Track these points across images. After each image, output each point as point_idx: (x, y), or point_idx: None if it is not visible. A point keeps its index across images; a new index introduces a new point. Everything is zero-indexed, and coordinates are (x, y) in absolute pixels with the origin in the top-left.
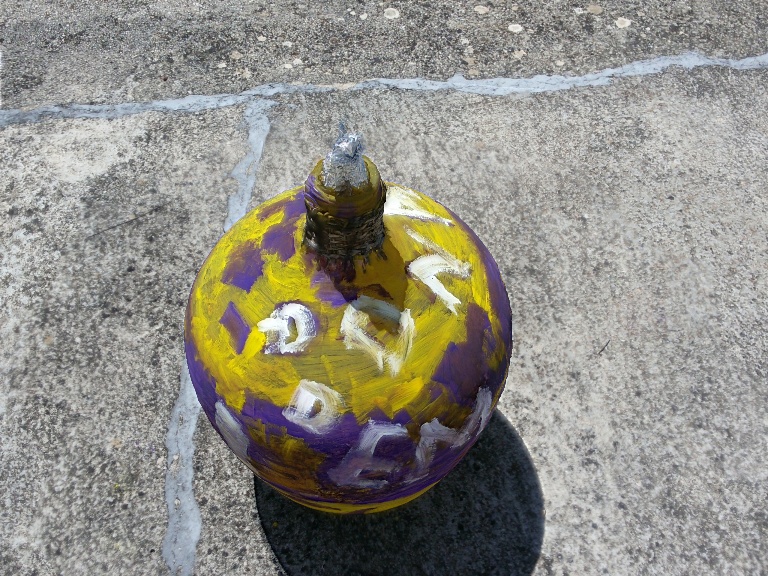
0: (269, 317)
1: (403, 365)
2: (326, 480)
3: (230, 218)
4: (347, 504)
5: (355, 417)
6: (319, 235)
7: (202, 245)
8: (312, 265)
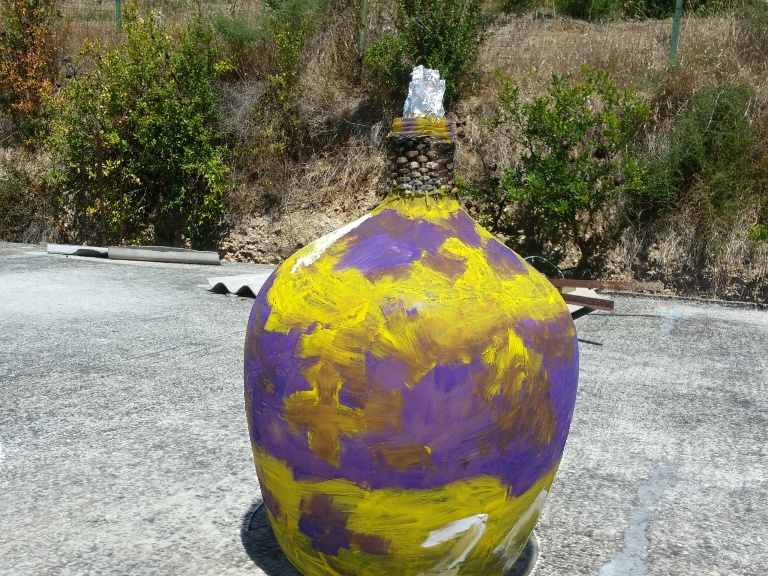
0: None
1: None
2: None
3: None
4: None
5: None
6: None
7: None
8: None
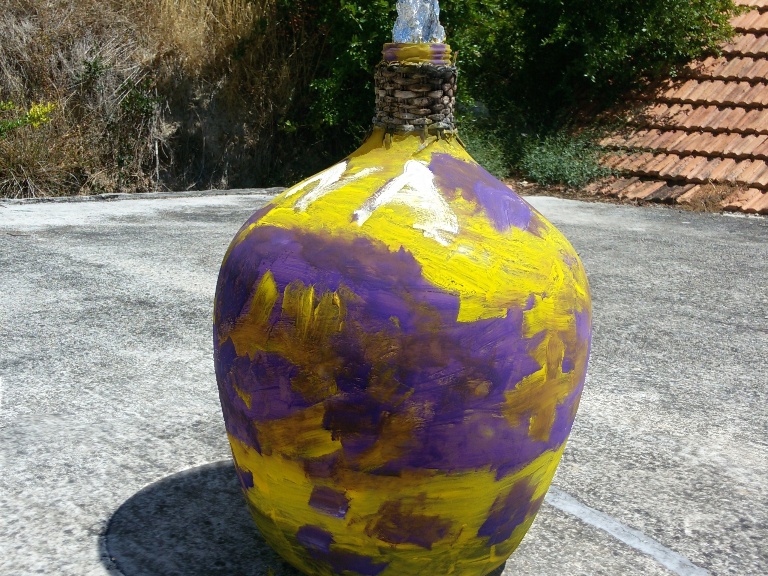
0: None
1: None
2: None
3: None
4: None
5: None
6: None
7: None
8: None
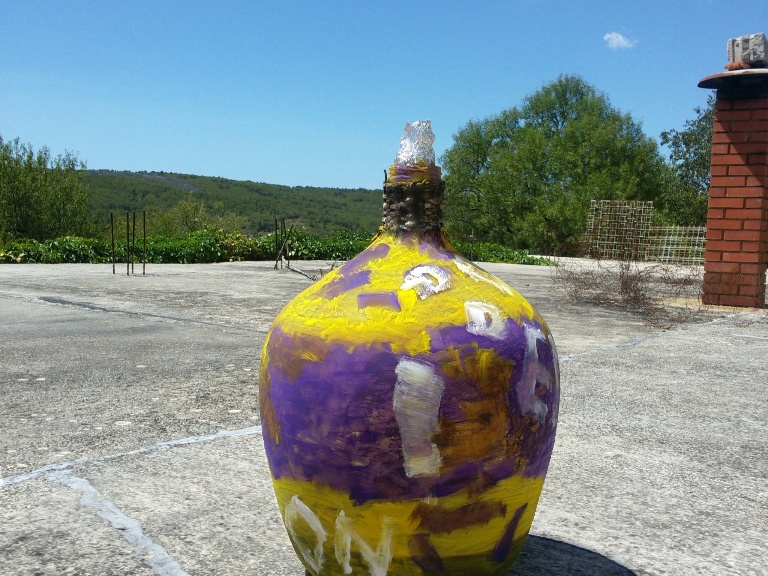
0: (405, 282)
1: None
2: (514, 407)
3: (115, 522)
4: (518, 478)
5: (515, 322)
6: (415, 212)
7: (106, 541)
8: (413, 244)
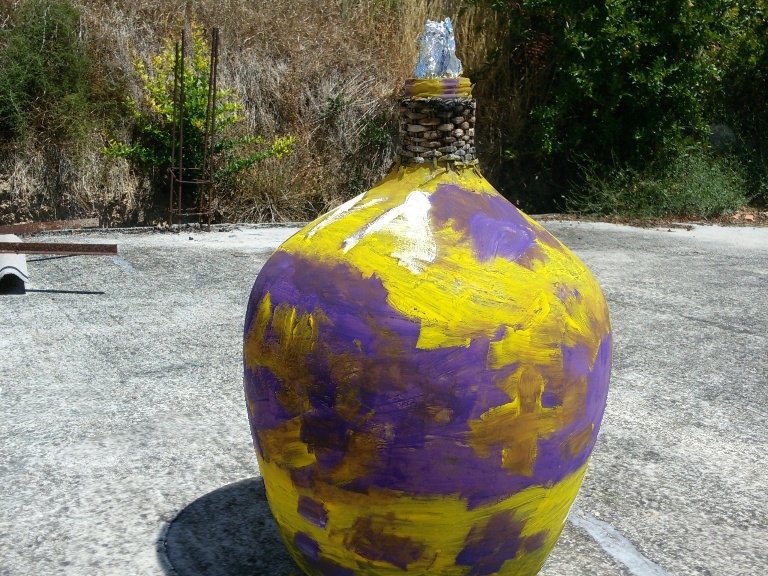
0: None
1: None
2: None
3: None
4: None
5: None
6: None
7: None
8: None
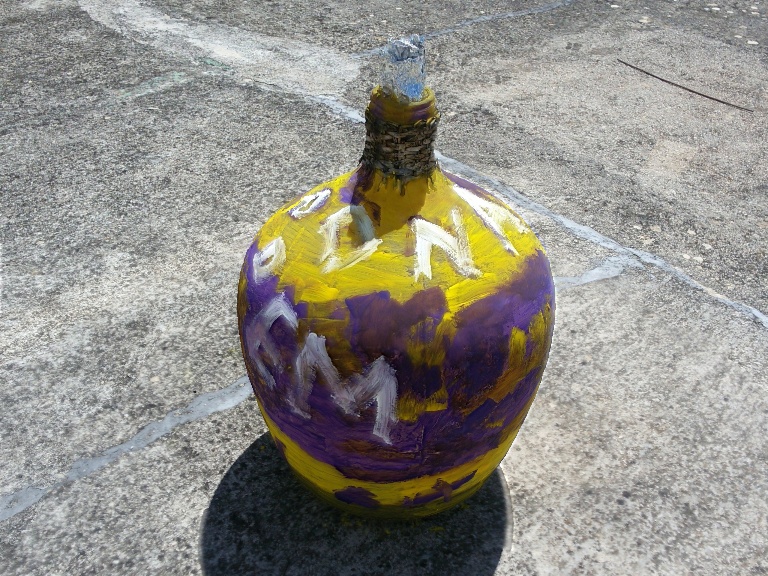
0: None
1: (337, 271)
2: None
3: None
4: None
5: (279, 283)
6: None
7: None
8: None
